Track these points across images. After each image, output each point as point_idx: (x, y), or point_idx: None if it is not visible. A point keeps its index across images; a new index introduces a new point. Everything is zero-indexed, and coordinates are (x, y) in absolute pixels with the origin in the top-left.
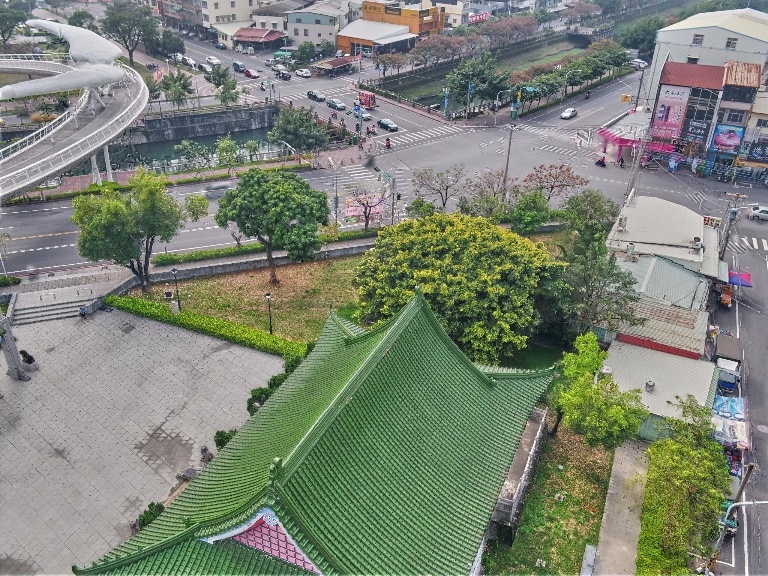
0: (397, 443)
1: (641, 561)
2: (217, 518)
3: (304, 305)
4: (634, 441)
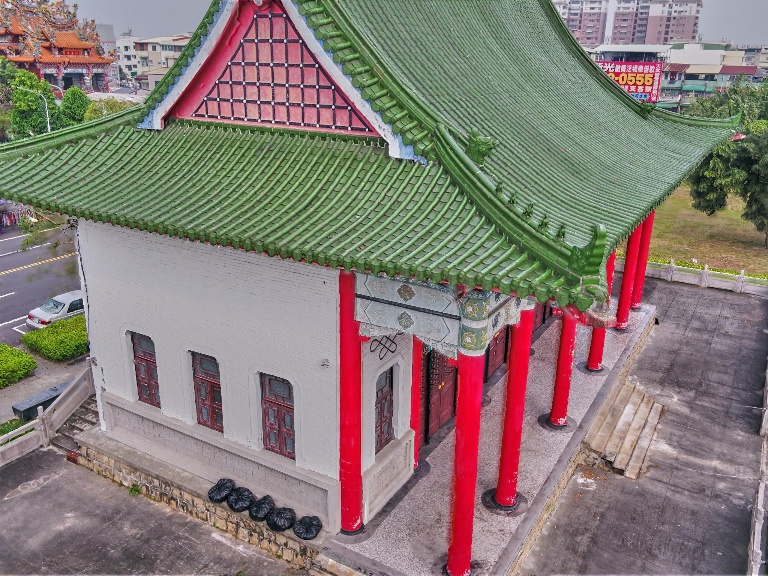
0: None
1: None
2: None
3: None
4: None
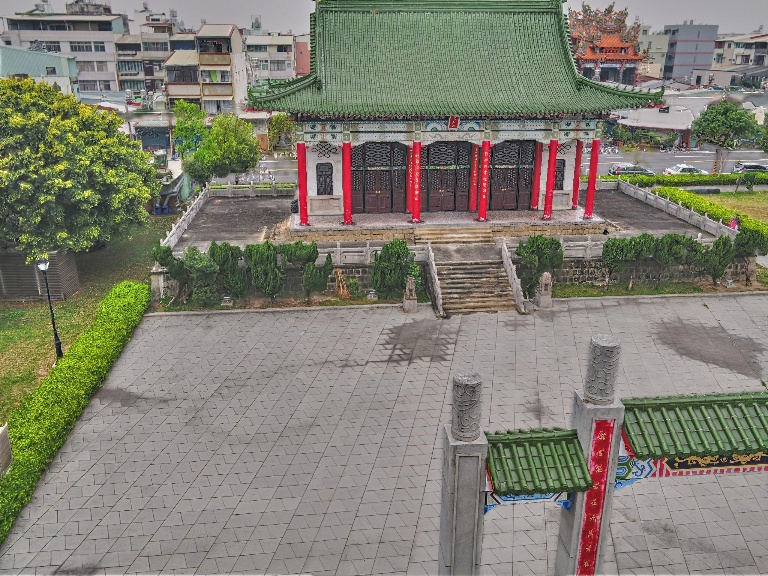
0: None
1: None
2: None
3: None
4: None
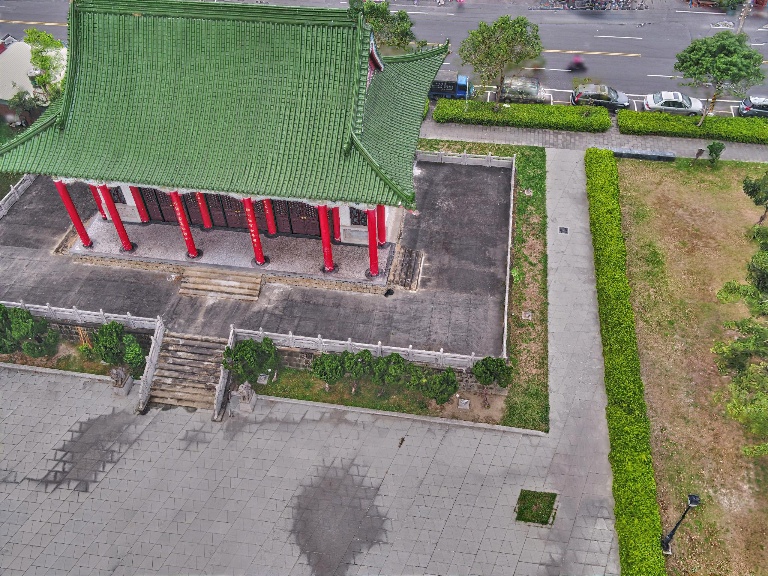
0: None
1: None
2: None
3: None
4: None
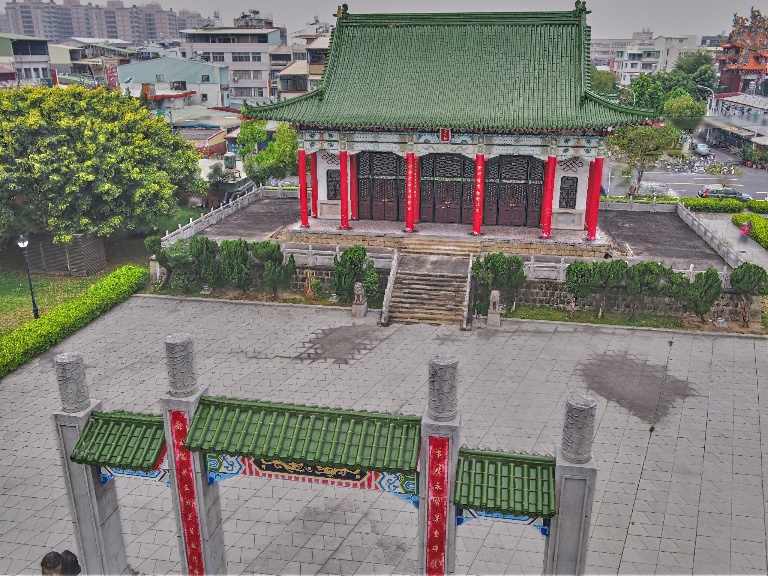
0: None
1: None
2: None
3: None
4: None
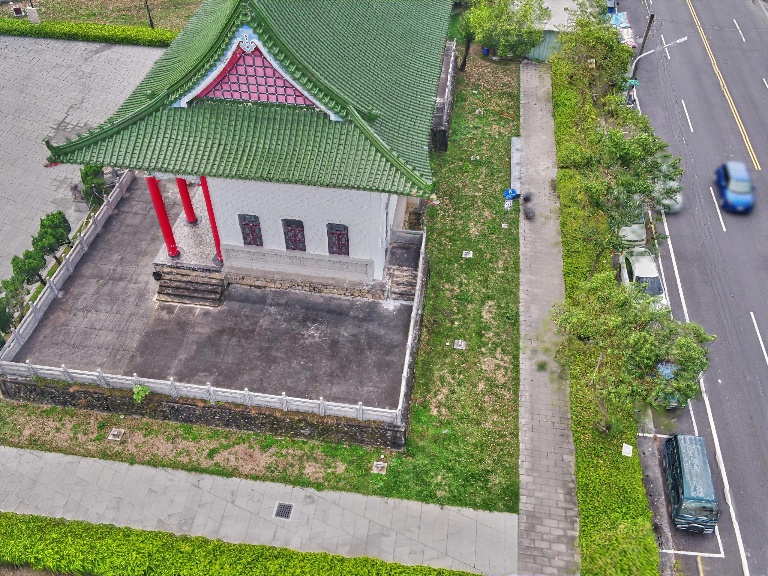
0: (343, 6)
1: (560, 139)
2: (186, 75)
3: (179, 4)
4: (535, 65)
